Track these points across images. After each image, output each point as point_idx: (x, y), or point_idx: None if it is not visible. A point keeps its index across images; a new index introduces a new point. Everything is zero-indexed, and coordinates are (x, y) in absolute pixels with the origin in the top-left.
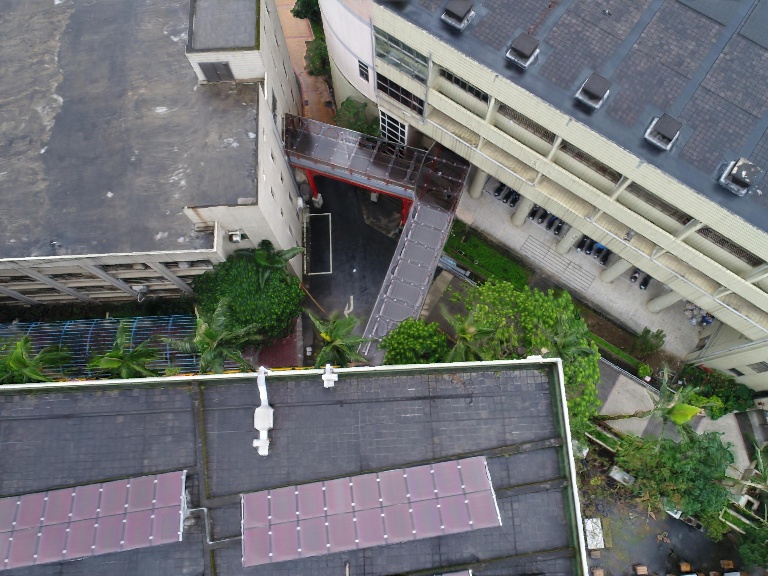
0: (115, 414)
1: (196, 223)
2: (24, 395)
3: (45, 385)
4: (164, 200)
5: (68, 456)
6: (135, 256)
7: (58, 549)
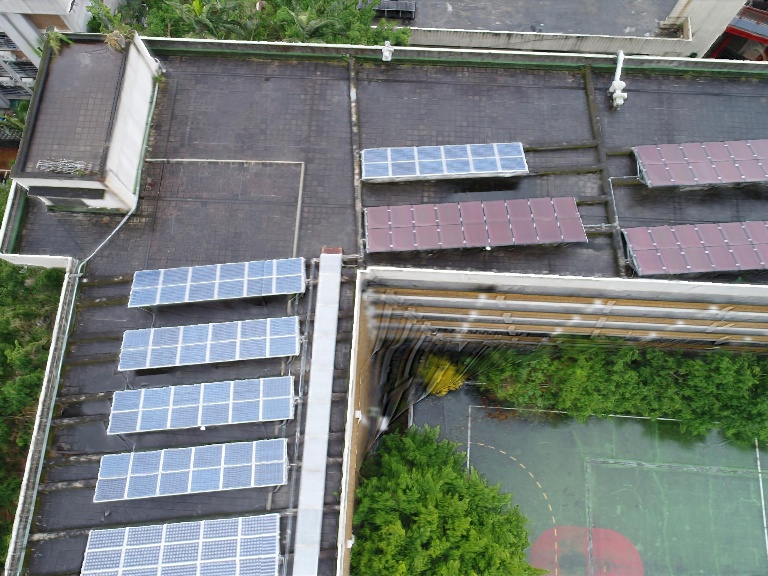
0: (758, 96)
1: (670, 18)
2: (678, 76)
3: (715, 60)
4: (628, 2)
5: (725, 123)
6: (617, 40)
7: (760, 174)
